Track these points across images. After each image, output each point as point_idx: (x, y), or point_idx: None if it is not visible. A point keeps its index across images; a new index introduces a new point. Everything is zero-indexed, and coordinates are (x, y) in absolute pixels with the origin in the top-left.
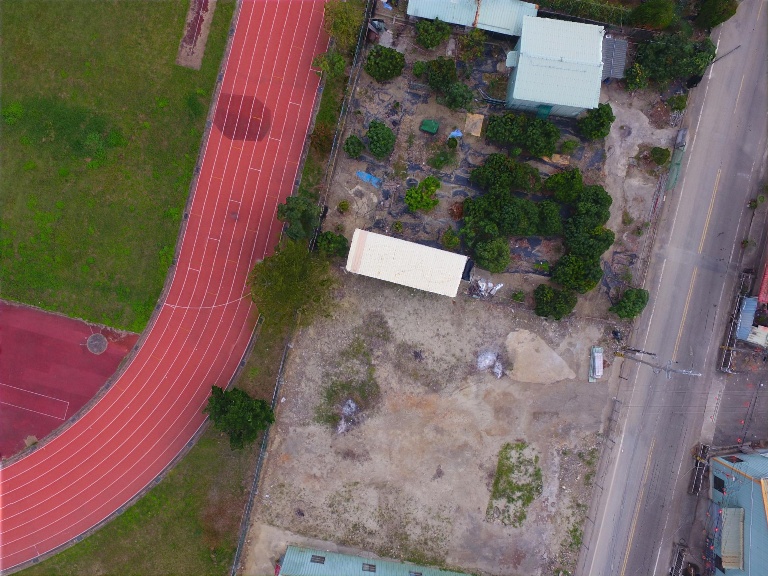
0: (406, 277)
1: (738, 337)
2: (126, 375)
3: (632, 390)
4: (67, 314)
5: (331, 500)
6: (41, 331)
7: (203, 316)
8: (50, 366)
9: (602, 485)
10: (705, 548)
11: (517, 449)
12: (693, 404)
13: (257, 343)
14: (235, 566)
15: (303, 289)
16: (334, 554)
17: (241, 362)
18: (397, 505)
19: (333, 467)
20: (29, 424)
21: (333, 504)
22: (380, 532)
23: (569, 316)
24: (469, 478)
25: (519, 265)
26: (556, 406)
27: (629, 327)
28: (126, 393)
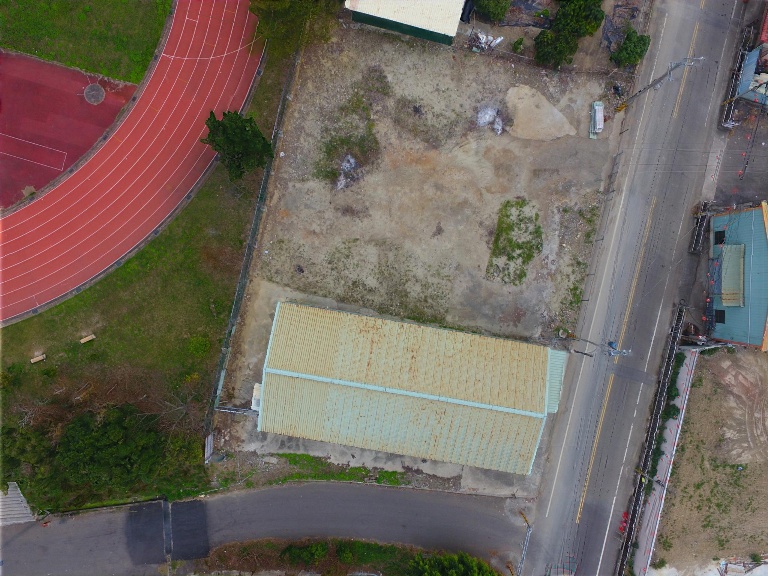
0: (405, 14)
1: (740, 92)
2: (124, 126)
3: (633, 148)
4: (64, 63)
5: (331, 257)
6: (38, 80)
7: (201, 67)
8: (47, 116)
9: (602, 236)
10: (705, 309)
11: (517, 207)
12: (694, 163)
13: (256, 95)
14: (235, 319)
15: (301, 2)
16: (334, 309)
17: (240, 114)
18: (397, 262)
19: (332, 223)
20: (27, 174)
21: (333, 261)
22: (380, 289)
23: (570, 71)
24: (469, 236)
25: (519, 18)
26: (556, 163)
27: (630, 81)
28: (124, 144)
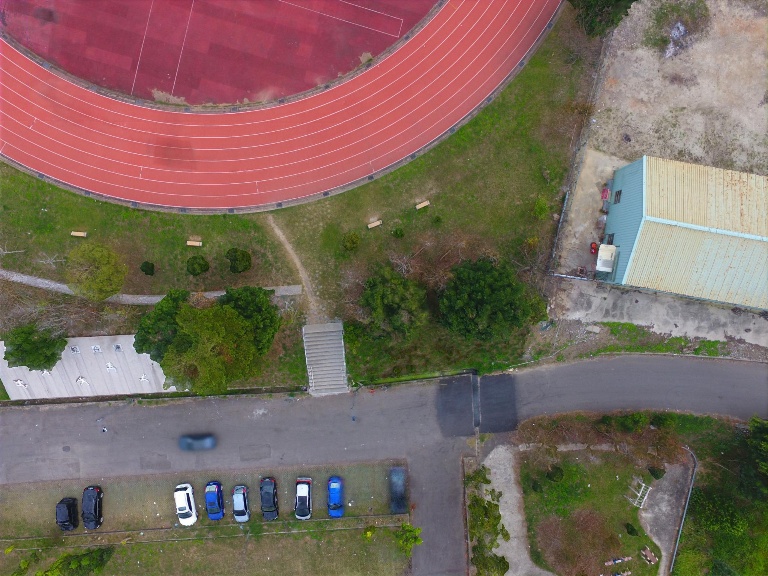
0: None
1: None
2: None
3: None
4: None
5: (658, 125)
6: None
7: None
8: None
9: None
10: None
11: None
12: None
13: None
14: (566, 186)
15: None
16: None
17: None
18: (723, 131)
19: (660, 92)
20: (364, 41)
21: (659, 129)
22: (706, 158)
23: None
24: None
25: None
26: None
27: None
28: (459, 10)
